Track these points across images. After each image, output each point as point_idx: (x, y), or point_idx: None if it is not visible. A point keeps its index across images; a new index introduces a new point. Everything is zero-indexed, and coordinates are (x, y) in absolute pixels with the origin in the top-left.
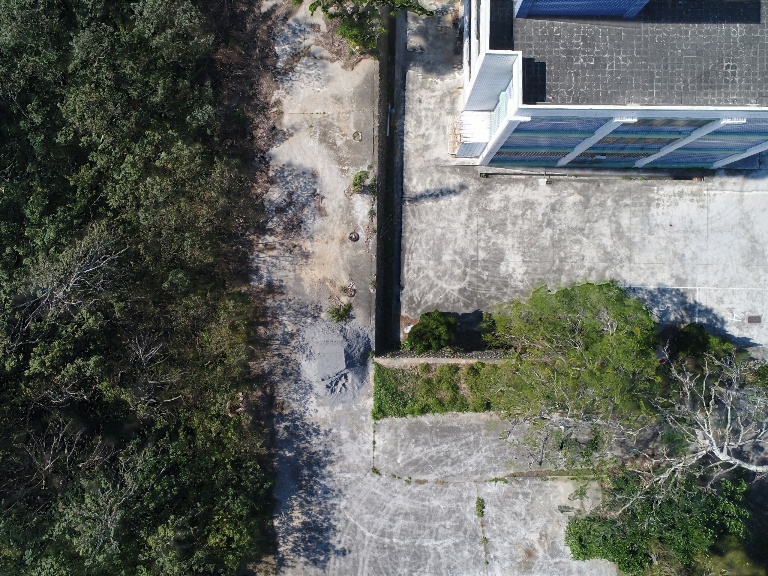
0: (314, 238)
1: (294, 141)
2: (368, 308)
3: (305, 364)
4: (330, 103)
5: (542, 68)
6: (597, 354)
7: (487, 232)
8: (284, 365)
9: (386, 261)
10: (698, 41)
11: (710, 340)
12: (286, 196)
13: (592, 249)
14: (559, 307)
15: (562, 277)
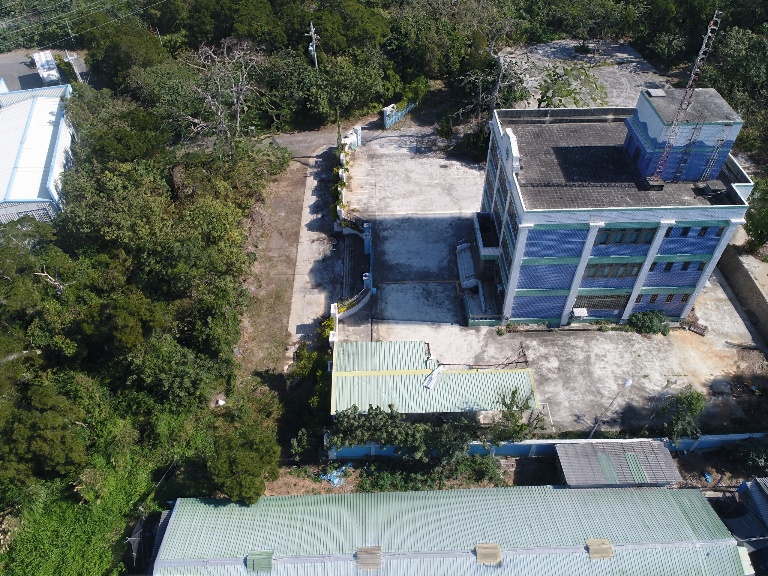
0: None
1: None
2: None
3: None
4: None
5: None
6: (571, 90)
7: None
8: None
9: None
10: (583, 141)
11: None
12: None
13: None
14: None
15: None
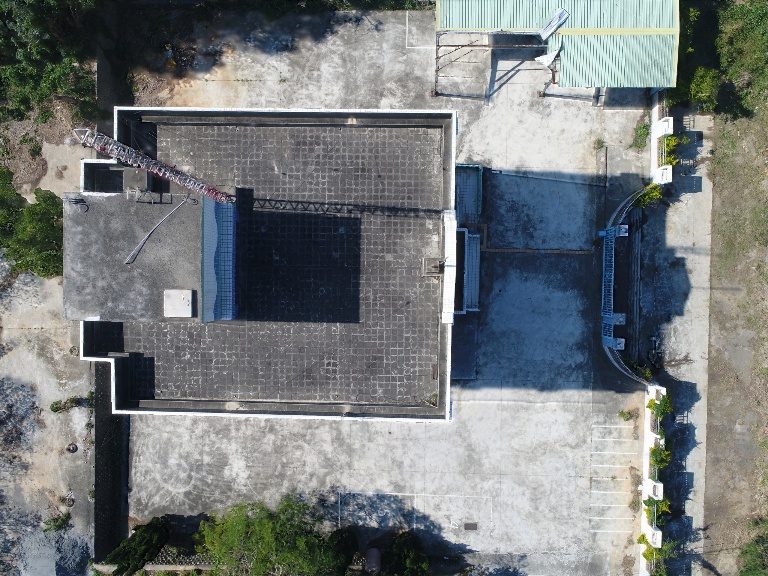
0: (33, 449)
1: (13, 355)
2: (87, 517)
3: (23, 573)
4: (48, 318)
5: (151, 362)
6: None
7: (211, 437)
8: (5, 572)
9: (114, 464)
10: (300, 339)
11: (406, 561)
12: (6, 409)
13: (313, 455)
14: (234, 545)
15: (284, 482)
